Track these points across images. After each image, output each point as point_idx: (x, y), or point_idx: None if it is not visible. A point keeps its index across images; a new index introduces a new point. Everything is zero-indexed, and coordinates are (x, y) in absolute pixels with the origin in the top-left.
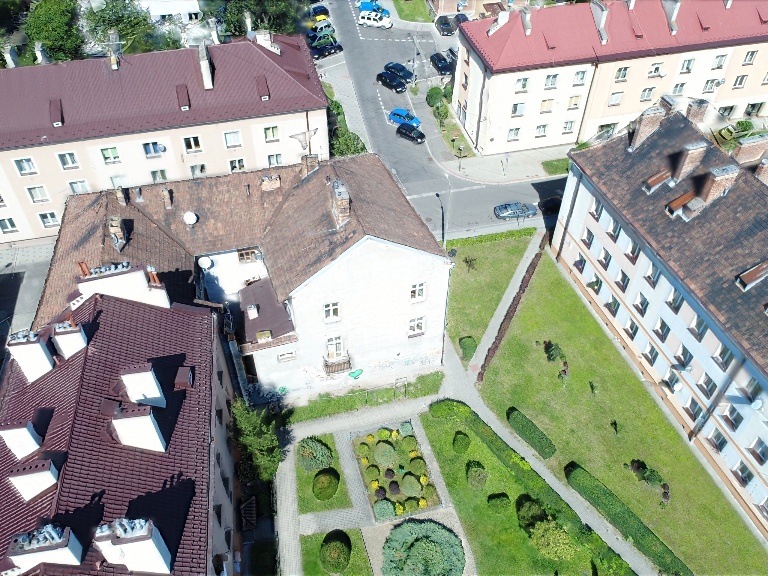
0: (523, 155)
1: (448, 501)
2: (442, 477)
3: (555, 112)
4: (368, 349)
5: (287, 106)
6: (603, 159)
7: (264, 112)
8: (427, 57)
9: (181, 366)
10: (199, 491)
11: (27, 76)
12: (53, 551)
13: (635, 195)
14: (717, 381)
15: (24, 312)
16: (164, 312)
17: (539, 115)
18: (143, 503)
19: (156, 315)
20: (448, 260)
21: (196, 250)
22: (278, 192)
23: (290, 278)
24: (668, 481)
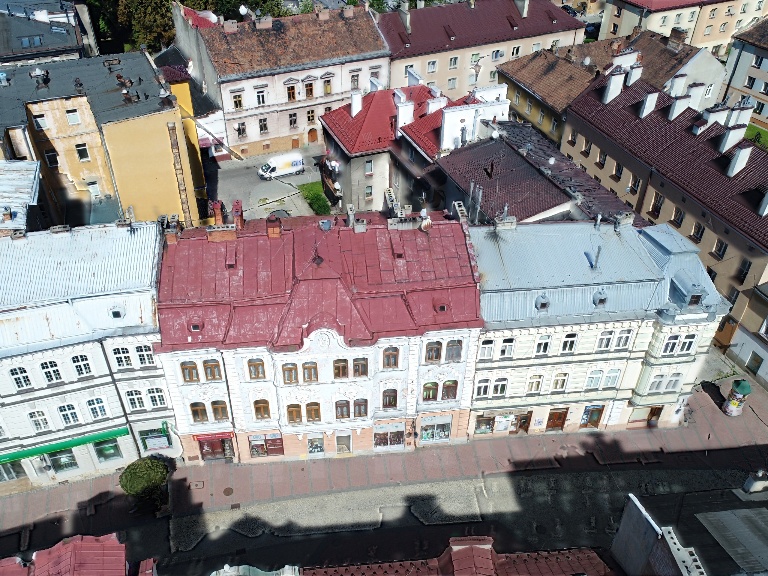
0: None
1: None
2: None
3: None
4: None
5: (567, 26)
6: (757, 33)
7: (556, 29)
8: None
9: None
10: None
11: (426, 13)
12: None
13: None
14: None
15: None
16: None
17: None
18: None
19: None
20: None
21: None
22: None
23: (658, 80)
24: None
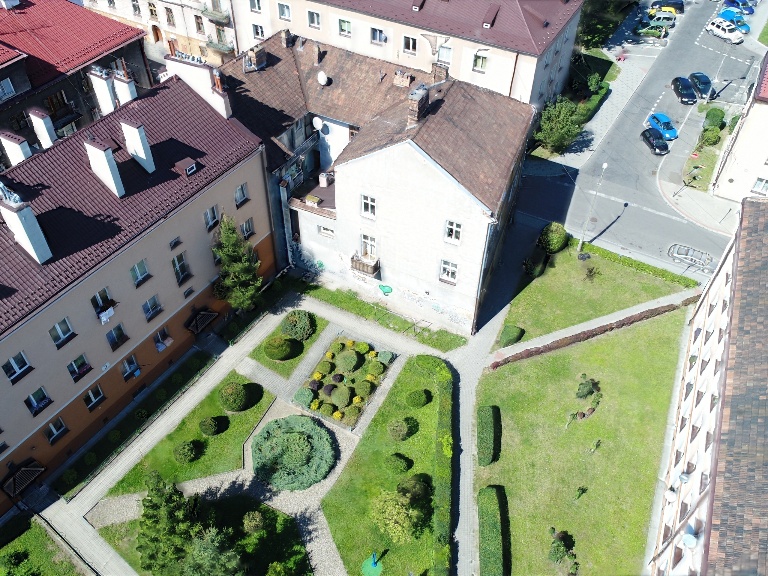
0: None
1: (361, 431)
2: (376, 411)
3: None
4: (399, 268)
5: (502, 40)
6: None
7: (478, 38)
8: (749, 84)
9: (191, 157)
10: (118, 238)
11: None
12: None
13: (766, 265)
14: (692, 503)
15: None
16: (220, 119)
17: None
18: (70, 214)
19: (211, 117)
20: (488, 211)
21: (314, 107)
22: (405, 91)
23: (349, 156)
24: (582, 575)
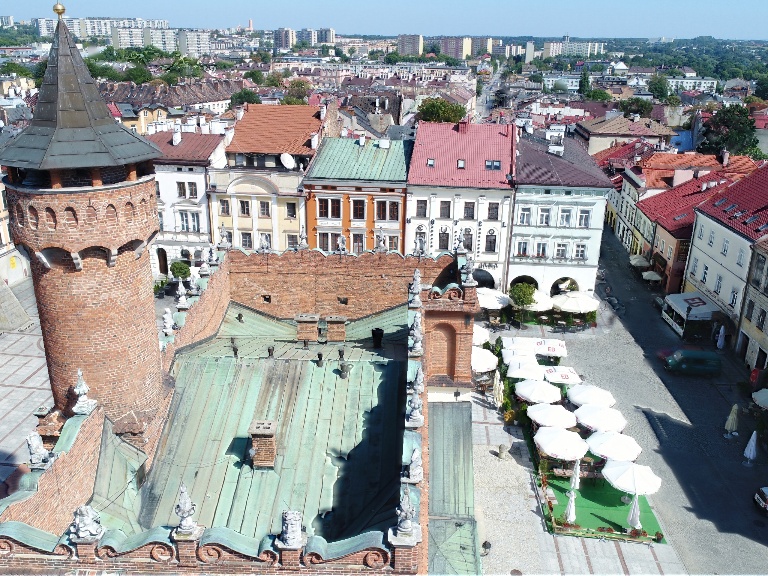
0: None
1: None
2: None
3: None
4: None
5: None
6: None
7: None
8: None
9: None
10: None
11: None
12: None
13: None
14: None
15: None
16: None
17: None
18: None
19: None
20: None
21: None
22: None
23: None
24: None
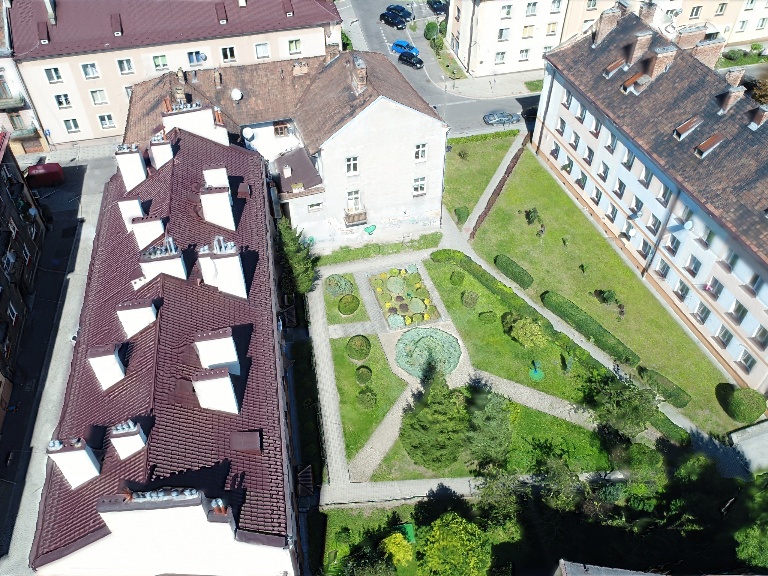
0: (509, 77)
1: (447, 317)
2: (442, 301)
3: (535, 37)
4: (381, 205)
5: (308, 21)
6: (572, 56)
7: (289, 26)
8: (424, 1)
9: (242, 182)
10: (262, 258)
11: None
12: (171, 262)
13: (597, 80)
14: (661, 218)
15: (90, 193)
16: (225, 149)
17: (522, 40)
18: None
19: (219, 149)
20: None
21: (241, 121)
22: (306, 77)
23: (319, 136)
24: (624, 304)
